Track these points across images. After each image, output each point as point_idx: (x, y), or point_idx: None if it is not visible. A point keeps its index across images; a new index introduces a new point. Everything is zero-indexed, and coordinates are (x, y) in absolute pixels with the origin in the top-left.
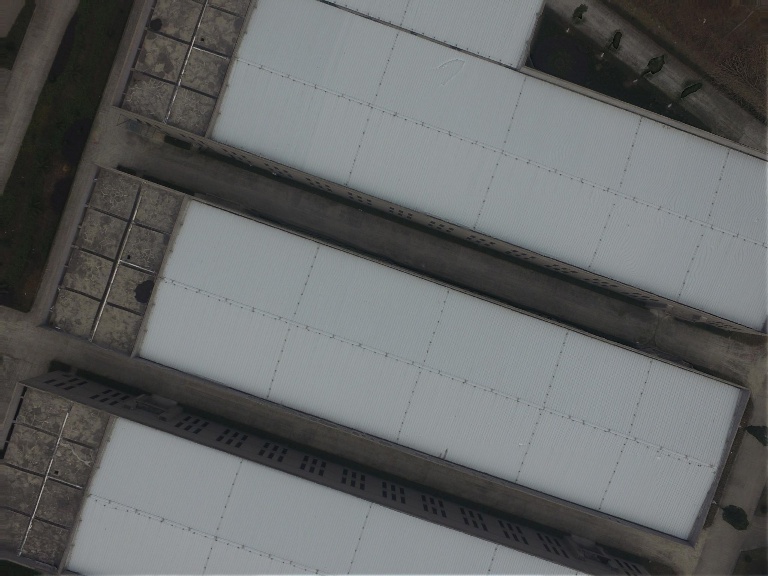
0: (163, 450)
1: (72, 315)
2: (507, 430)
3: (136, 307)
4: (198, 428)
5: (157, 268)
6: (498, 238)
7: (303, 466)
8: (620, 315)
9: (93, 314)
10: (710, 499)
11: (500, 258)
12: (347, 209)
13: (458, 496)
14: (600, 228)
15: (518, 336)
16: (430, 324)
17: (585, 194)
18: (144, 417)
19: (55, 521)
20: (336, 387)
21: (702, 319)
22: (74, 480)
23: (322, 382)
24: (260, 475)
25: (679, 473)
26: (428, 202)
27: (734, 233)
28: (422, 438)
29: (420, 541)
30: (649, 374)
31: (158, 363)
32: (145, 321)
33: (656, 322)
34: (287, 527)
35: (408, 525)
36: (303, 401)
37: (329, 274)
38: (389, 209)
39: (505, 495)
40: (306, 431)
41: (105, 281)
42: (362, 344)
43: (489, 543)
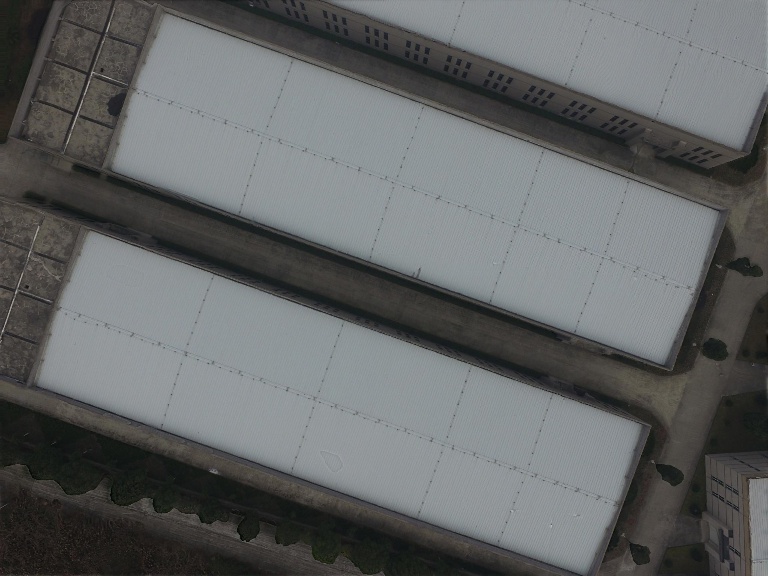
0: (134, 264)
1: (44, 128)
2: (481, 248)
3: (108, 120)
4: (171, 252)
5: (130, 79)
6: (473, 53)
7: (276, 290)
8: (599, 153)
9: (65, 127)
10: (687, 320)
11: (478, 93)
12: (324, 43)
13: (434, 335)
14: (576, 41)
15: (493, 154)
16: (404, 140)
17: (561, 8)
18: (116, 234)
19: (25, 336)
20: (308, 203)
21: (681, 144)
22: (44, 295)
23: (294, 197)
24: (231, 291)
25: (656, 295)
26: (402, 14)
27: (713, 50)
28: (395, 256)
29: (392, 361)
30: (626, 194)
31: (130, 178)
32: (117, 133)
33: (636, 161)
34: (258, 343)
35: (380, 345)
36: (275, 217)
37: (302, 85)
38: (365, 34)
39: (482, 334)
40: (281, 266)
41: (78, 94)
42: (335, 158)
43: (462, 365)
